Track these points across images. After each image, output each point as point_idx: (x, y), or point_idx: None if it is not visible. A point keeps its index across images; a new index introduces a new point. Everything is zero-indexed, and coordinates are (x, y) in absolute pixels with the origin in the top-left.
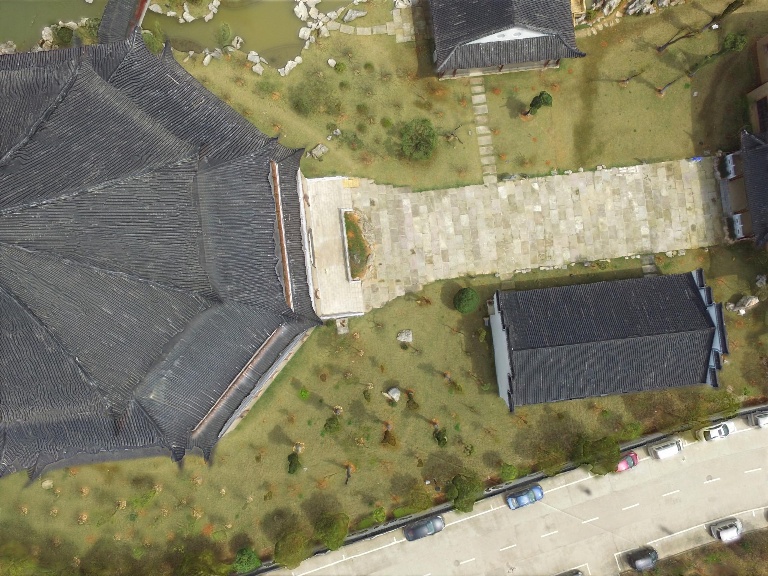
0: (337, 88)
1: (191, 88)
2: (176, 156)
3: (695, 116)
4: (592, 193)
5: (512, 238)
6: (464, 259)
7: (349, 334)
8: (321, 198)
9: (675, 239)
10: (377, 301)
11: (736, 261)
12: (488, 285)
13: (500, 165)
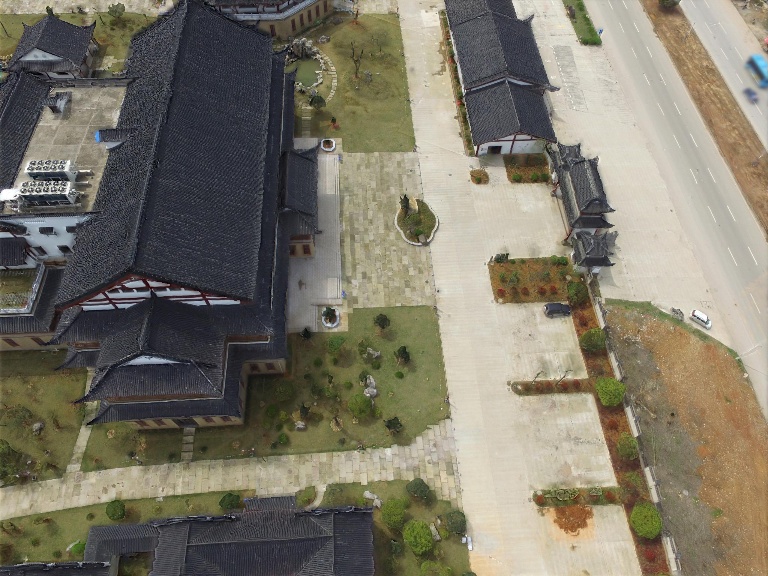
0: None
1: None
2: None
3: None
4: (45, 7)
5: None
6: None
7: None
8: None
9: None
10: None
11: None
12: None
13: (84, 17)
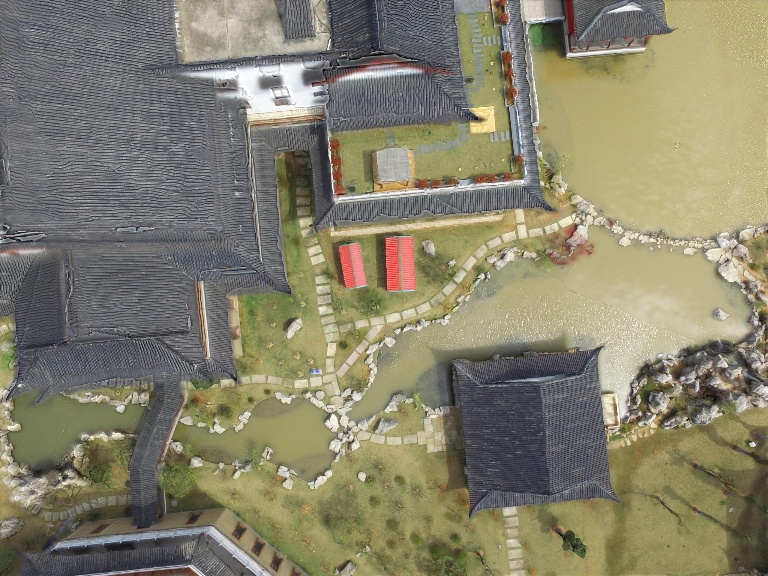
0: (367, 503)
1: None
2: None
3: (730, 531)
4: None
5: None
6: None
7: None
8: None
9: None
10: None
11: None
12: None
13: None
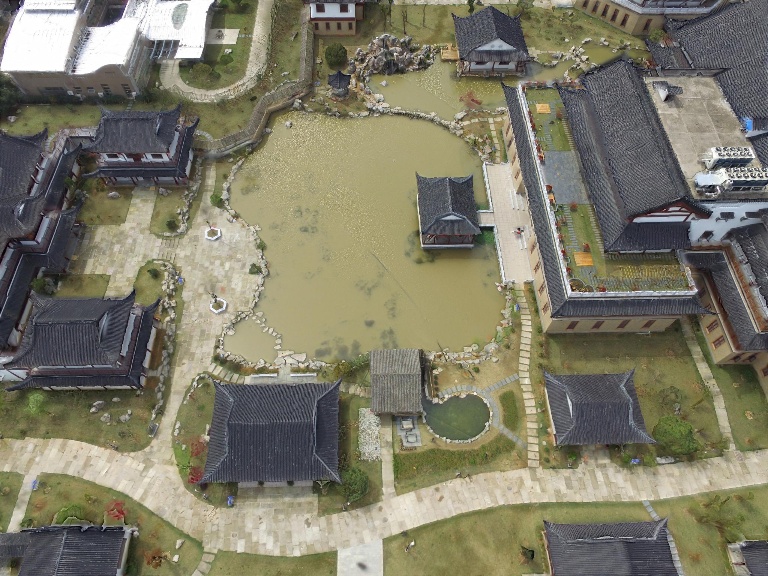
0: (563, 33)
1: None
2: None
3: None
4: None
5: None
6: None
7: None
8: (566, 2)
9: None
10: None
11: None
12: None
13: (483, 8)
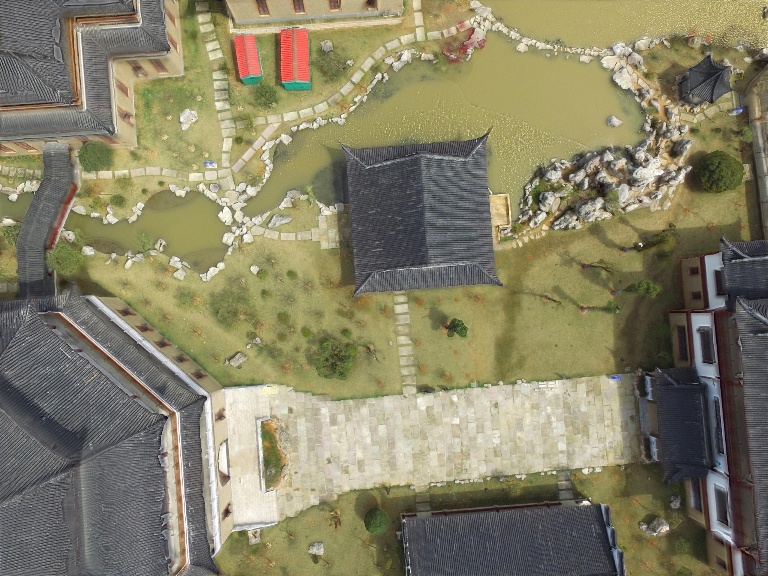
0: (258, 295)
1: (83, 362)
2: (48, 474)
3: (617, 332)
4: (511, 407)
5: (429, 450)
6: (380, 470)
7: (261, 544)
8: (238, 406)
9: (592, 456)
10: (291, 510)
11: (651, 481)
12: (403, 497)
13: (420, 376)
